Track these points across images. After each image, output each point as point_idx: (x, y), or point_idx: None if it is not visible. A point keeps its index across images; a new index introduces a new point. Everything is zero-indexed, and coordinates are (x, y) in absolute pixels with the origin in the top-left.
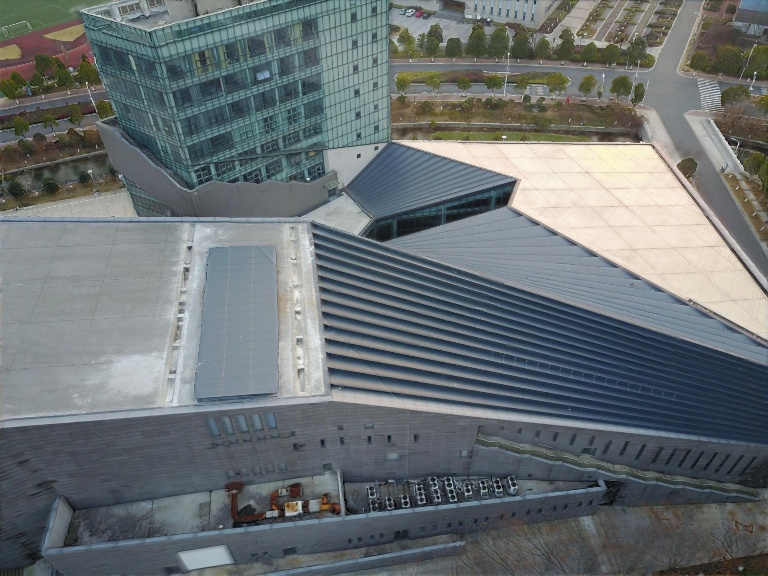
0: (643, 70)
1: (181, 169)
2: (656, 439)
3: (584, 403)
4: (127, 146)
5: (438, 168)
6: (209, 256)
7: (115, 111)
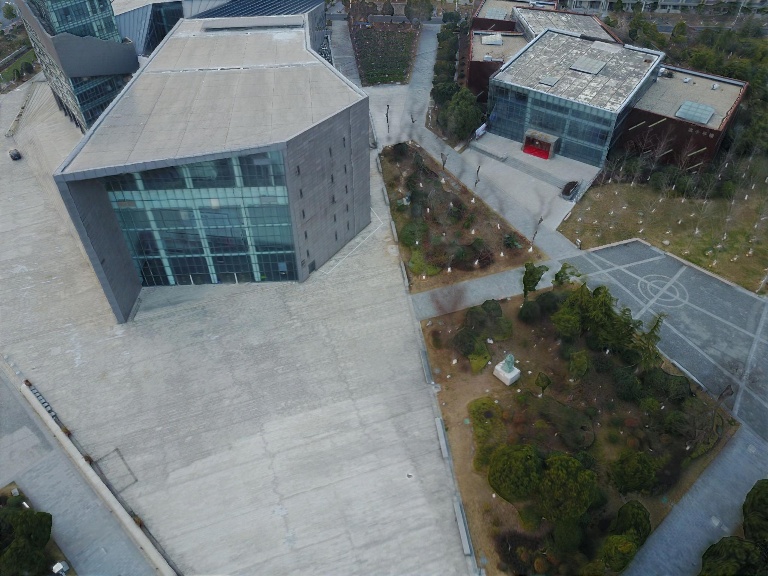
0: None
1: (113, 36)
2: (320, 7)
3: (307, 4)
4: (81, 39)
5: (120, 22)
6: (209, 28)
7: (55, 22)
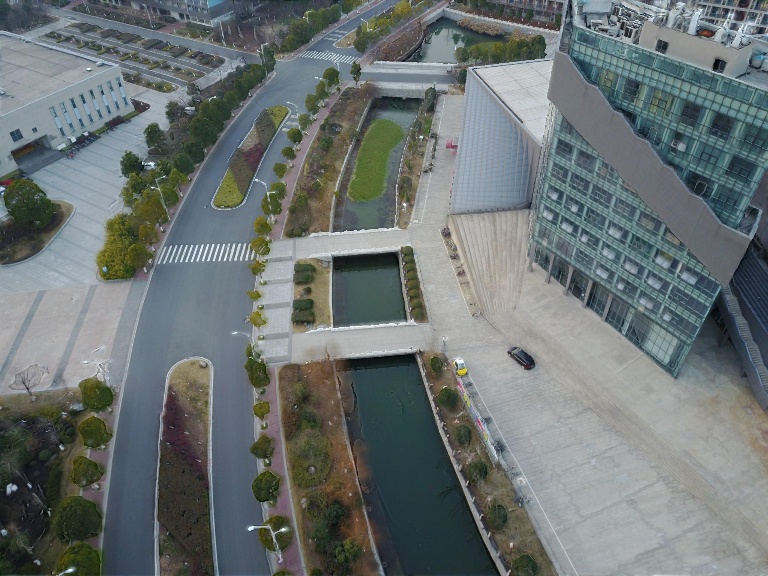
0: (273, 73)
1: None
2: None
3: None
4: None
5: None
6: None
7: None
